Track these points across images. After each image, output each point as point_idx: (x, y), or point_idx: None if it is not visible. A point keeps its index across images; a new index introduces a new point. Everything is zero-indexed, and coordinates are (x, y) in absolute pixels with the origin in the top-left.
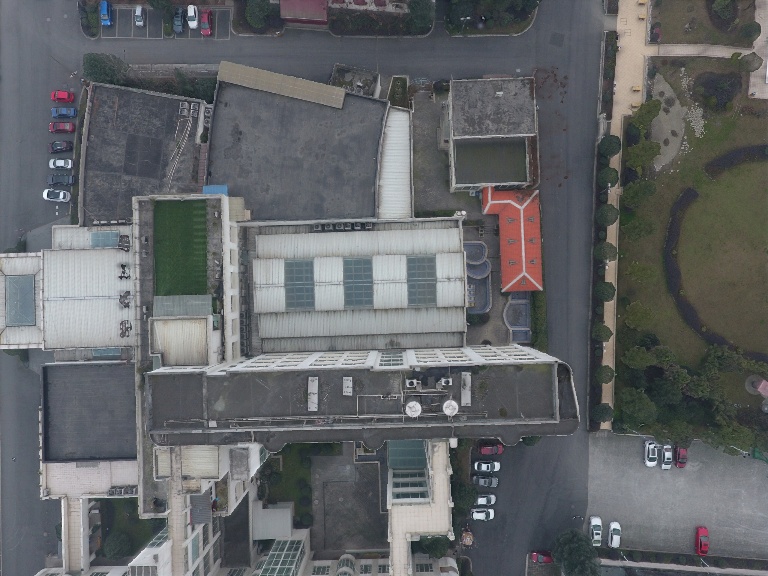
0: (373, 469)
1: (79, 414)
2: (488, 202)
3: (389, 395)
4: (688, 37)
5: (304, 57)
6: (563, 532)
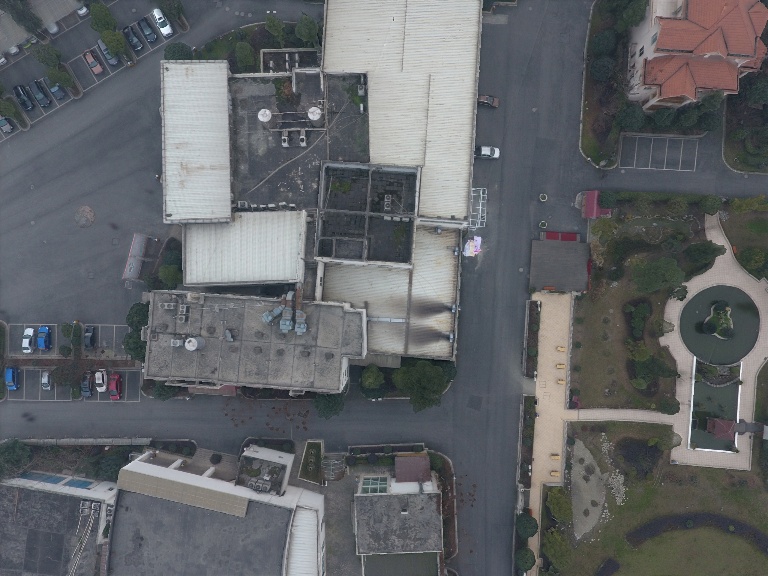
0: None
1: None
2: None
3: None
4: (608, 400)
5: (216, 420)
6: None
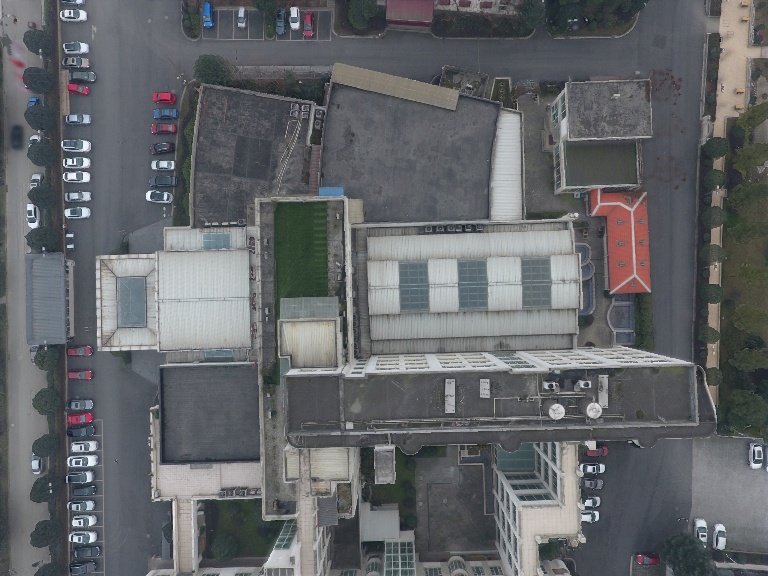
0: (477, 471)
1: (195, 416)
2: (597, 204)
3: (527, 397)
4: None
5: (406, 59)
6: (673, 534)
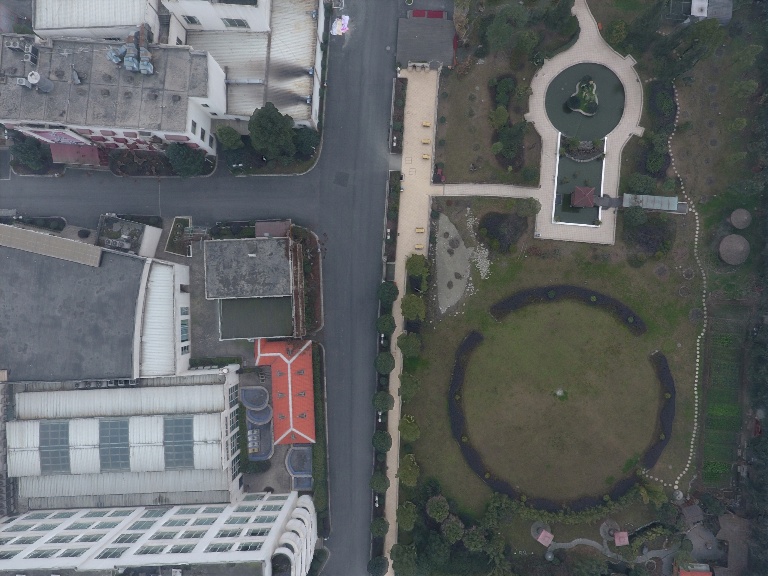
0: None
1: None
2: (258, 355)
3: None
4: (474, 176)
5: (86, 198)
6: None
